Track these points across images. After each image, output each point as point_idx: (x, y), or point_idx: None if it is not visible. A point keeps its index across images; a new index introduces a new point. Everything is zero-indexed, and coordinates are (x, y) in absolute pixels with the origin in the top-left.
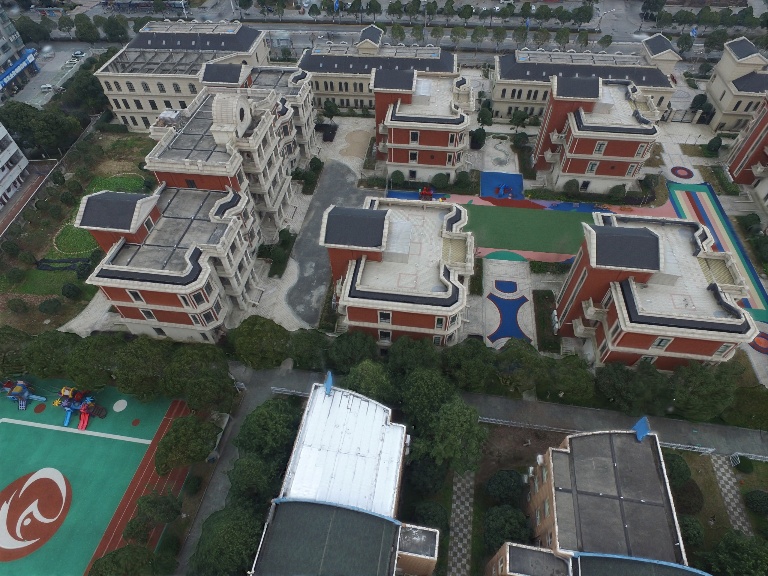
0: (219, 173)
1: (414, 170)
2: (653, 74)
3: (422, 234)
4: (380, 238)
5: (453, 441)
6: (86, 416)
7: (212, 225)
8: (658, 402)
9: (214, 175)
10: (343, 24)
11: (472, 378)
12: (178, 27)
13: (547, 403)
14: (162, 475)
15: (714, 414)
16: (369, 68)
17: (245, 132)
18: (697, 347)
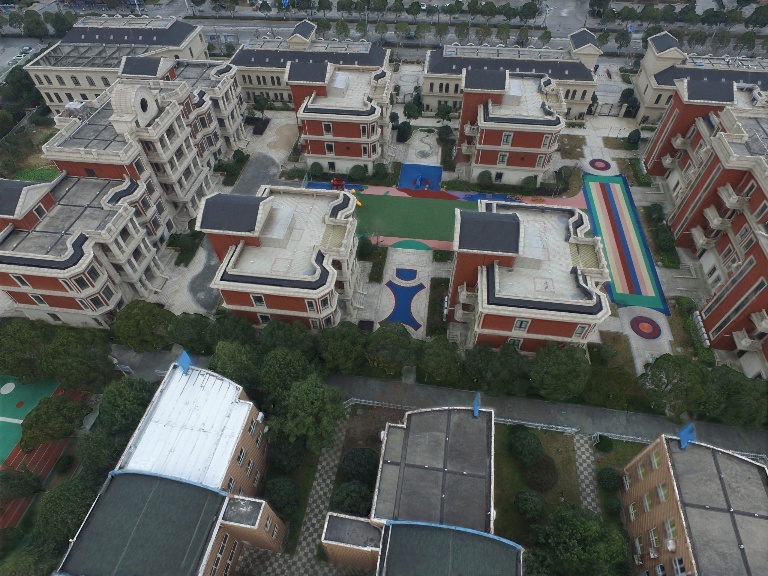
0: (114, 162)
1: (332, 162)
2: (575, 68)
3: (306, 221)
4: (254, 223)
5: (304, 418)
6: None
7: (104, 212)
8: (517, 382)
9: (110, 164)
10: (294, 21)
11: (338, 359)
12: (112, 22)
13: (424, 386)
14: (26, 453)
15: (572, 394)
16: None
17: (149, 122)
18: (556, 329)
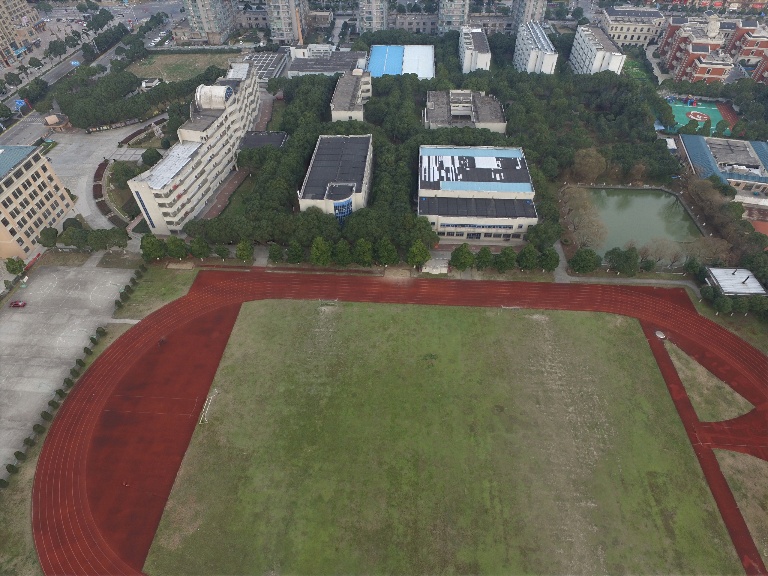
0: (719, 43)
1: (750, 59)
2: None
3: None
4: None
5: None
6: (695, 103)
7: None
8: None
9: (716, 44)
10: None
11: None
12: (629, 8)
13: None
14: None
15: None
16: None
17: None
18: None
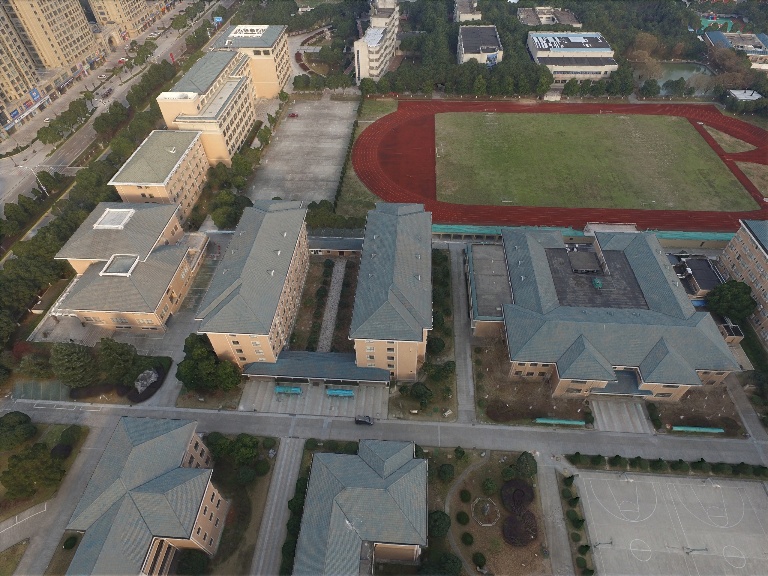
0: None
1: None
2: None
3: None
4: None
5: None
6: (715, 18)
7: None
8: None
9: None
10: None
11: None
12: None
13: None
14: None
15: None
16: None
17: None
18: None
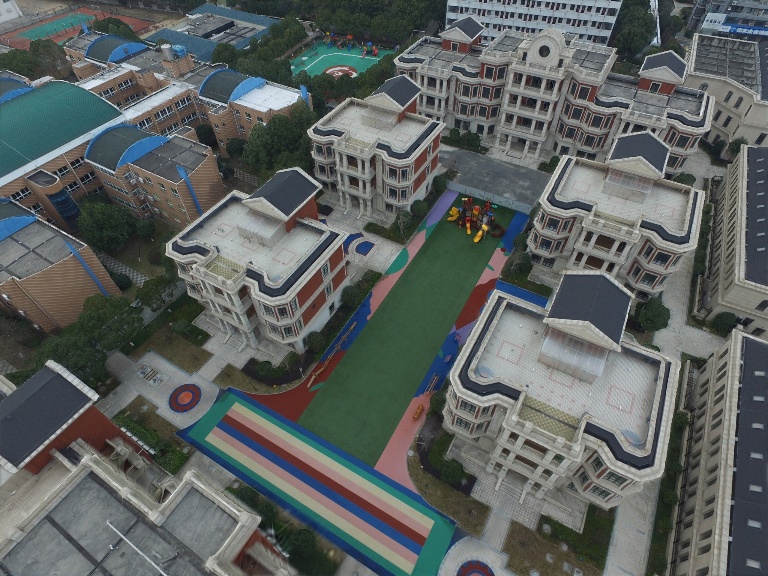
0: None
1: None
2: None
3: (385, 135)
4: (372, 95)
5: None
6: None
7: None
8: None
9: None
10: None
11: None
12: None
13: None
14: None
15: None
16: (759, 197)
17: None
18: None
